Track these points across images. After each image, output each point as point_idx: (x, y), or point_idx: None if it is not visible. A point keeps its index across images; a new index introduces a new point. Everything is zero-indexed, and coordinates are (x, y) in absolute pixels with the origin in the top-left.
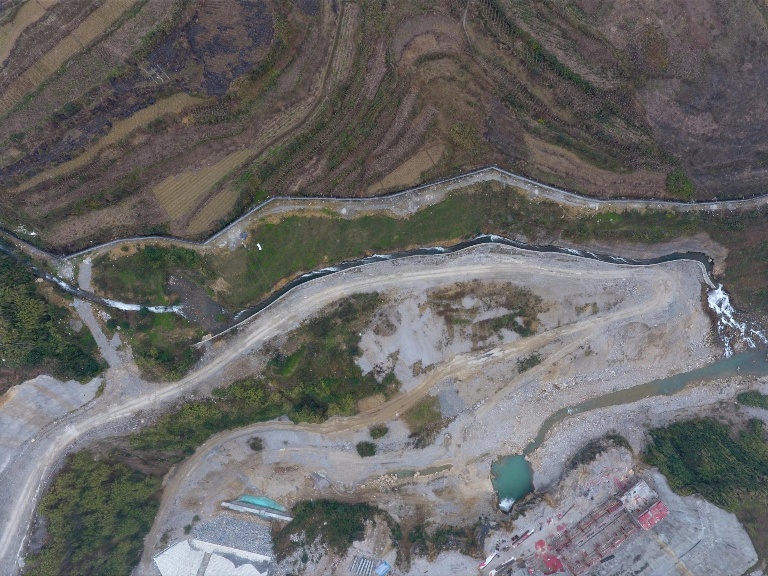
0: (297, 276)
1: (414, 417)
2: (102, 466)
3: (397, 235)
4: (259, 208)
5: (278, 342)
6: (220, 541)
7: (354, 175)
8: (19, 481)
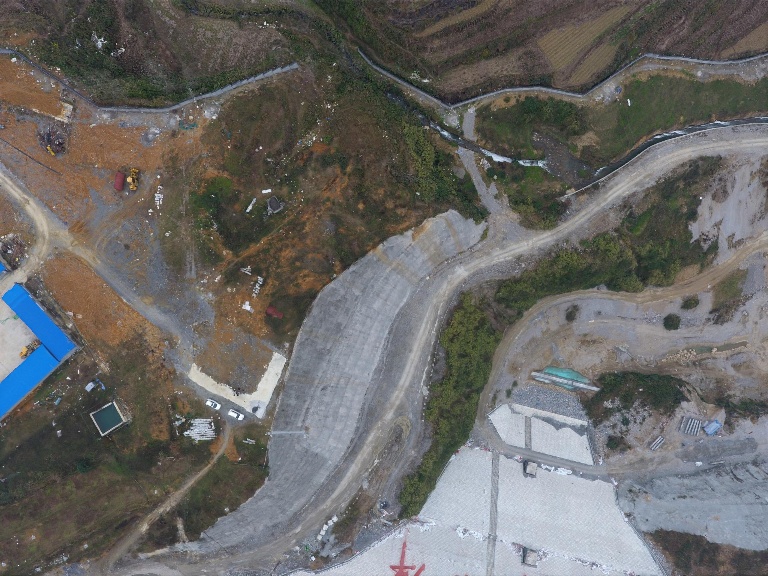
0: (651, 137)
1: (724, 290)
2: (477, 310)
3: (743, 101)
4: (631, 64)
5: (635, 199)
6: (538, 406)
7: (715, 37)
8: (418, 315)
